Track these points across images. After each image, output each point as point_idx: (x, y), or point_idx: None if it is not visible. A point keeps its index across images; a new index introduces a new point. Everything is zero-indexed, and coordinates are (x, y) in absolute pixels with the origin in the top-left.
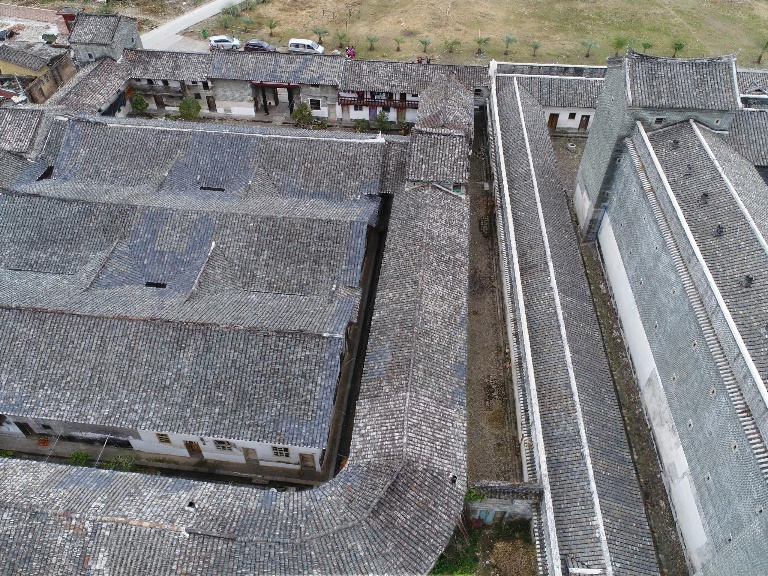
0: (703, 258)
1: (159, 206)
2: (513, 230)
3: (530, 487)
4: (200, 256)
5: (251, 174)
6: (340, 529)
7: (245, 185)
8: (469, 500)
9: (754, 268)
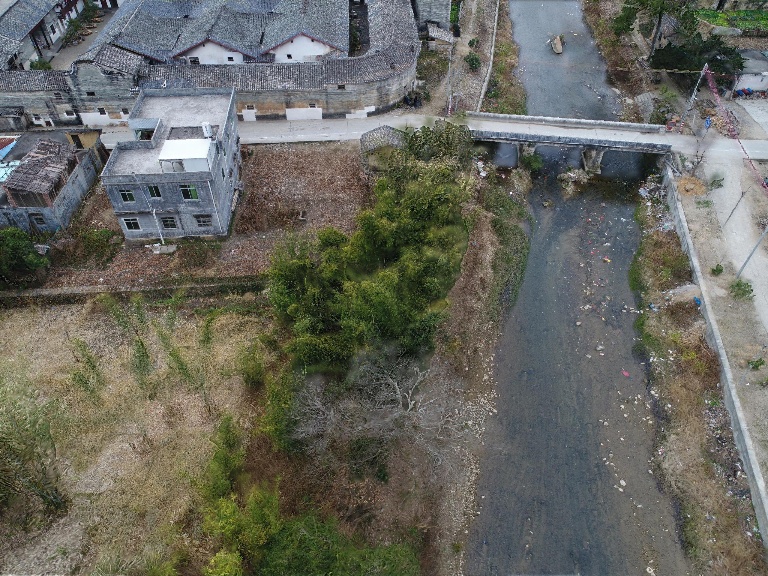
0: None
1: None
2: None
3: None
4: (254, 0)
5: (180, 1)
6: None
7: (190, 2)
8: None
9: None
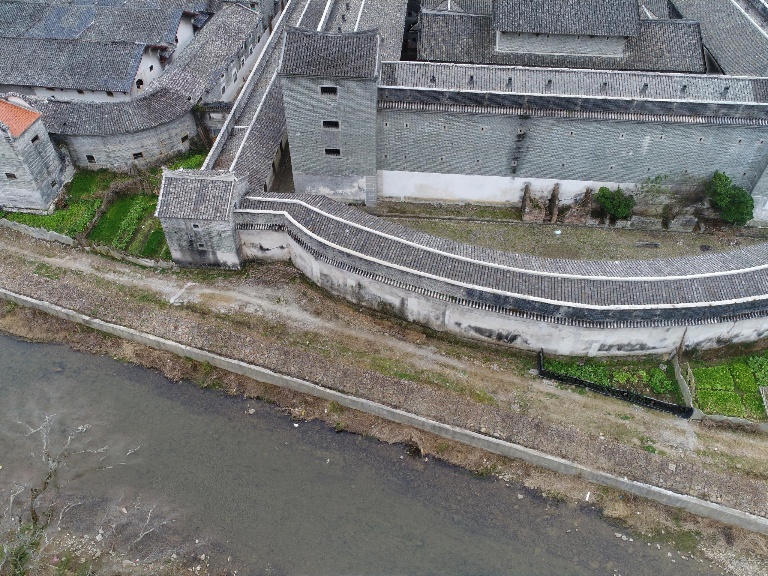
0: (339, 5)
1: (63, 4)
2: (278, 24)
3: (228, 103)
4: None
5: None
6: (121, 103)
7: None
8: (198, 110)
9: (355, 3)
